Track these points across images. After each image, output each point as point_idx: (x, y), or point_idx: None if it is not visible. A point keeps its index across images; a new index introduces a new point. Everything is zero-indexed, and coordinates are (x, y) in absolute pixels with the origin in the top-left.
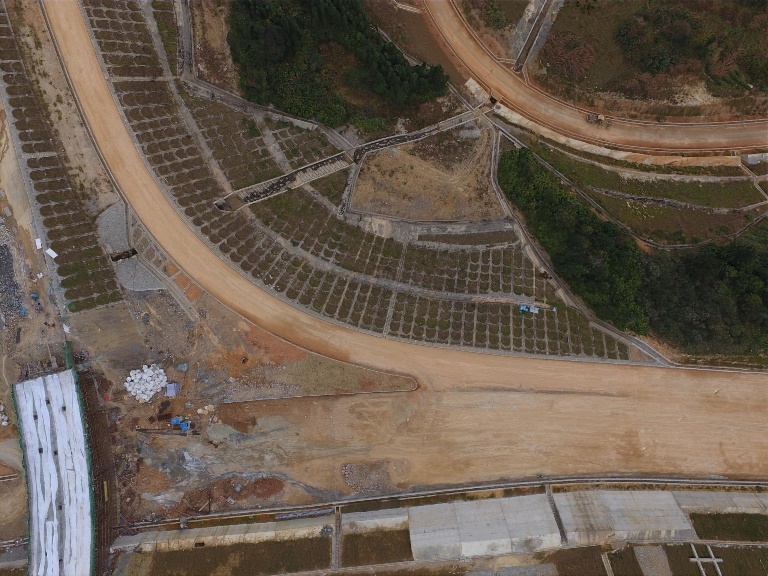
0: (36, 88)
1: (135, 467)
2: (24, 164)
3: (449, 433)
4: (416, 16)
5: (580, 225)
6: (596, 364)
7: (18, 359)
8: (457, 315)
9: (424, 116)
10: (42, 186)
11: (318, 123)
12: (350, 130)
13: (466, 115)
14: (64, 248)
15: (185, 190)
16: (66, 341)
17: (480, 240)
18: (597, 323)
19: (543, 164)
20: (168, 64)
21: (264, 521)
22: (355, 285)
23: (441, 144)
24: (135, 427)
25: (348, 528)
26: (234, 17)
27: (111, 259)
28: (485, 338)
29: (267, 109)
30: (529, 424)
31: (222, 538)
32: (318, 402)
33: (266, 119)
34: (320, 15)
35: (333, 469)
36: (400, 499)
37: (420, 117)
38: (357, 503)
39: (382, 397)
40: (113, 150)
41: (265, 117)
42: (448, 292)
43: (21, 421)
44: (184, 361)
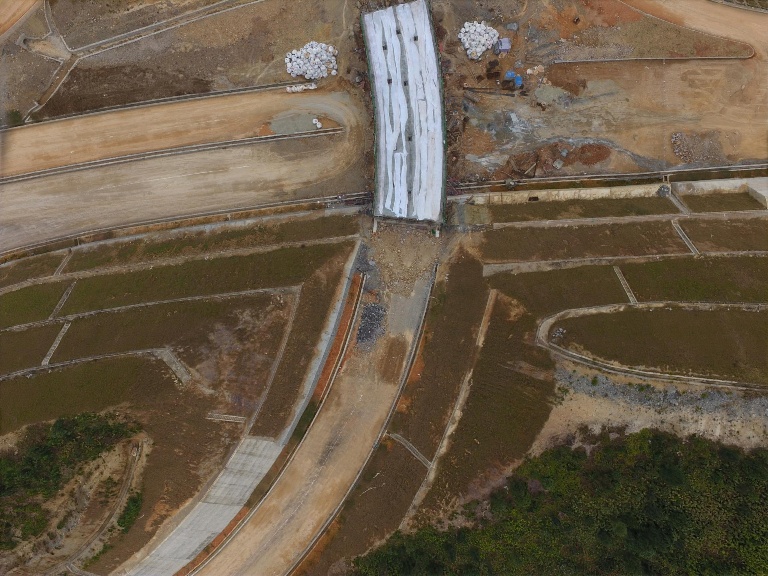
0: None
1: (461, 126)
2: None
3: None
4: None
5: None
6: None
7: None
8: None
9: None
10: None
11: None
12: None
13: None
14: None
15: None
16: None
17: None
18: None
19: None
20: None
21: (591, 186)
22: None
23: None
24: (463, 85)
25: (685, 189)
26: None
27: None
28: None
29: None
30: None
31: (557, 193)
32: (650, 67)
33: None
34: None
35: (662, 138)
36: (730, 170)
37: None
38: (686, 172)
39: (716, 65)
40: None
41: None
42: None
43: (369, 51)
44: (513, 21)
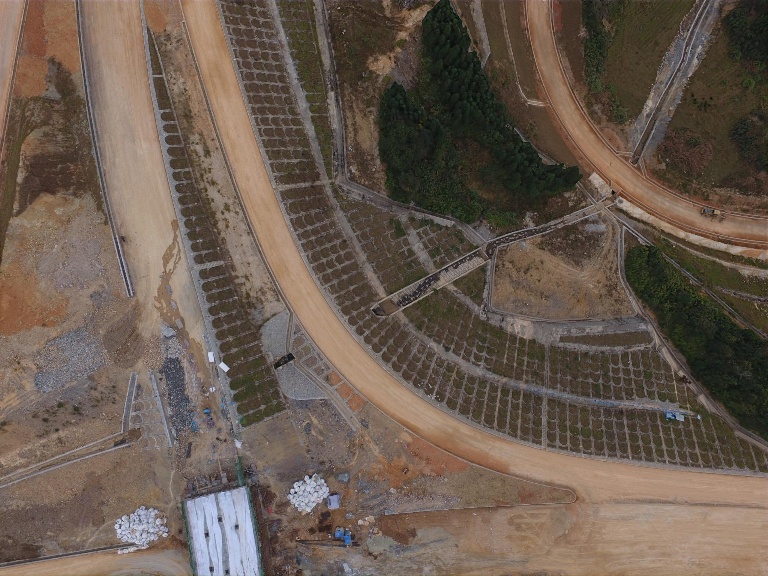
0: (204, 196)
1: None
2: (196, 276)
3: (605, 545)
4: (542, 110)
5: (720, 332)
6: (748, 477)
7: (187, 474)
8: (608, 423)
9: (551, 210)
10: (213, 297)
11: (454, 219)
12: (483, 225)
13: (590, 208)
14: (234, 360)
15: (346, 298)
16: (238, 457)
17: (618, 341)
18: (742, 432)
19: (670, 262)
20: (324, 168)
21: None
22: (507, 391)
23: (568, 238)
24: (295, 538)
25: None
26: (382, 118)
27: (274, 368)
28: (640, 450)
29: (408, 206)
30: (683, 536)
31: None
32: (478, 513)
33: (411, 219)
34: (463, 116)
35: None
36: None
37: (547, 211)
38: None
39: (541, 509)
40: (278, 259)
41: (409, 216)
42: (596, 398)
43: (192, 539)
44: (345, 471)
